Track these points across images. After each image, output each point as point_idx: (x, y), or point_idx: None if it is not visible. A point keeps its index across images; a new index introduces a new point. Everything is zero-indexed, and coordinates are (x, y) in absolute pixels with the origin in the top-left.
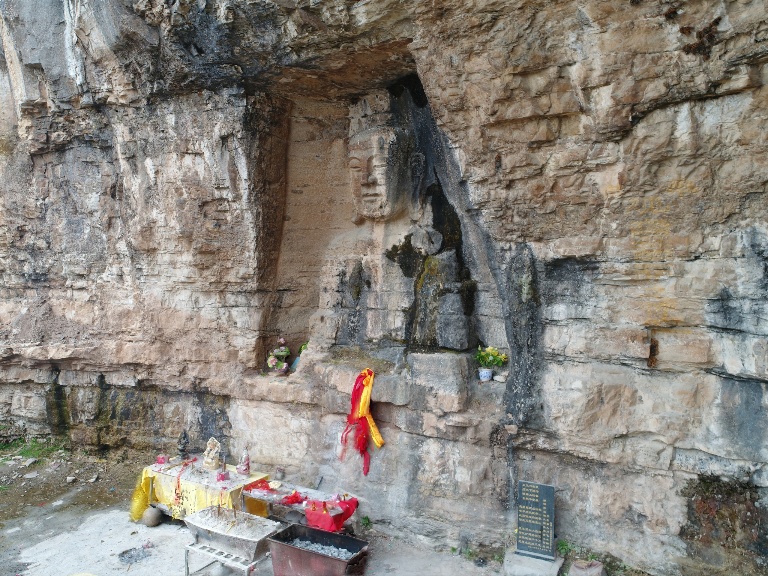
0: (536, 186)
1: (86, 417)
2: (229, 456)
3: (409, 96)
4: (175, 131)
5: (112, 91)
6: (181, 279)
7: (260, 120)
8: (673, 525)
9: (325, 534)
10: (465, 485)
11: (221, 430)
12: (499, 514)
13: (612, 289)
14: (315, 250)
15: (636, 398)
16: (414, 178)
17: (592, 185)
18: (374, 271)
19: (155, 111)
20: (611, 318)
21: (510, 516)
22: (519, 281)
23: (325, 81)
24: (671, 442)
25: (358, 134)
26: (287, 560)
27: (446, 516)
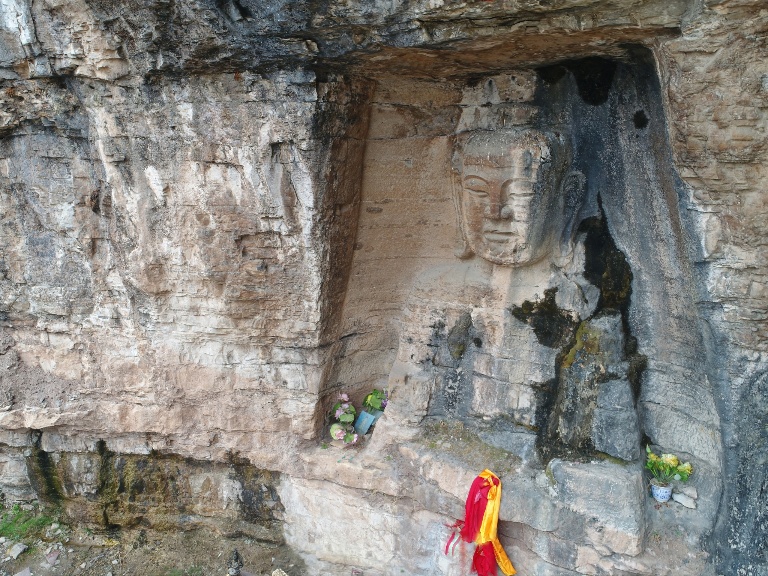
0: None
1: (85, 490)
2: (283, 545)
3: (573, 84)
4: (194, 129)
5: (83, 58)
6: (208, 330)
7: (334, 119)
8: None
9: None
10: None
11: (270, 512)
12: None
13: None
14: (392, 283)
15: None
16: (566, 208)
17: None
18: (490, 329)
19: (158, 95)
20: None
21: None
22: (767, 408)
23: (445, 60)
24: None
25: (486, 141)
26: None
27: None
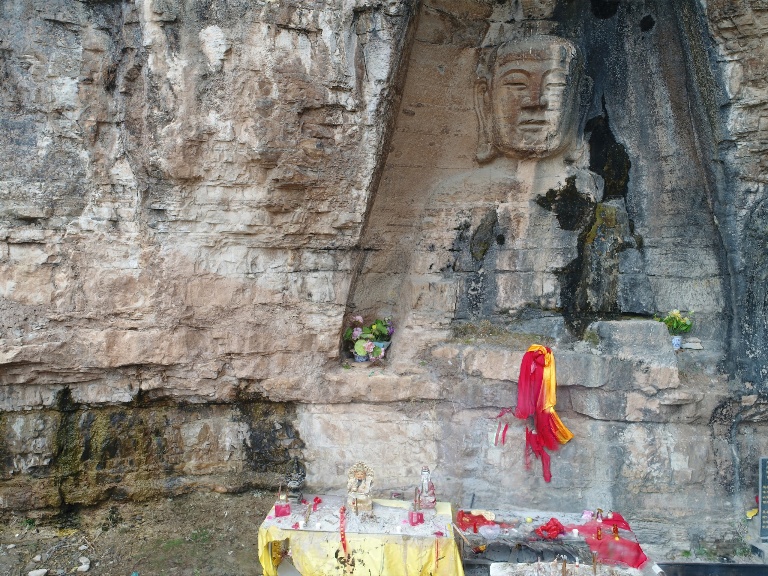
0: None
1: (31, 463)
2: (303, 488)
3: (587, 2)
4: None
5: None
6: (238, 228)
7: None
8: None
9: (711, 568)
10: (686, 473)
11: (286, 452)
12: (724, 501)
13: None
14: (410, 196)
15: None
16: (580, 107)
17: None
18: (515, 223)
19: None
20: None
21: (736, 501)
22: (767, 228)
23: None
24: None
25: (525, 40)
26: None
27: (664, 514)
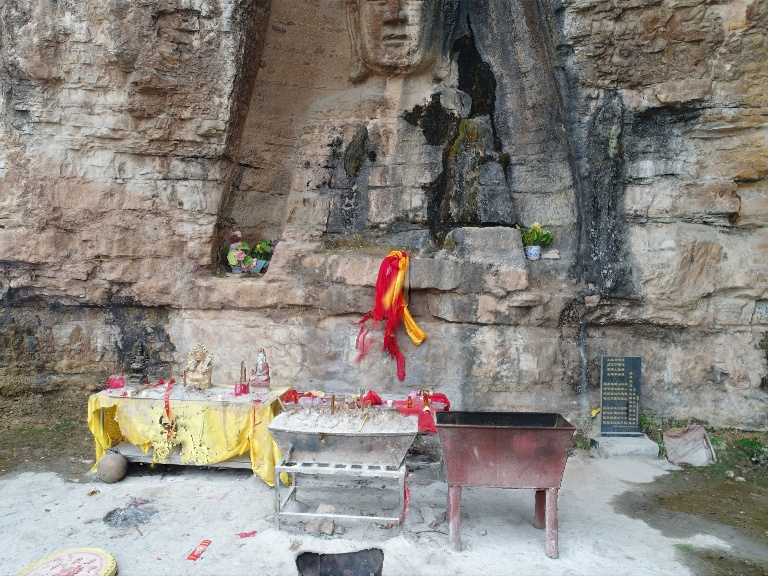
0: (652, 17)
1: None
2: None
3: None
4: None
5: None
6: (101, 131)
7: None
8: (755, 378)
9: (487, 416)
10: (533, 373)
11: (157, 355)
12: (571, 400)
13: (701, 143)
14: (288, 116)
15: (721, 255)
16: (445, 25)
17: (714, 19)
18: (384, 139)
19: None
20: (698, 174)
21: (583, 400)
22: (607, 133)
23: None
24: (760, 294)
25: None
26: (471, 448)
27: None
